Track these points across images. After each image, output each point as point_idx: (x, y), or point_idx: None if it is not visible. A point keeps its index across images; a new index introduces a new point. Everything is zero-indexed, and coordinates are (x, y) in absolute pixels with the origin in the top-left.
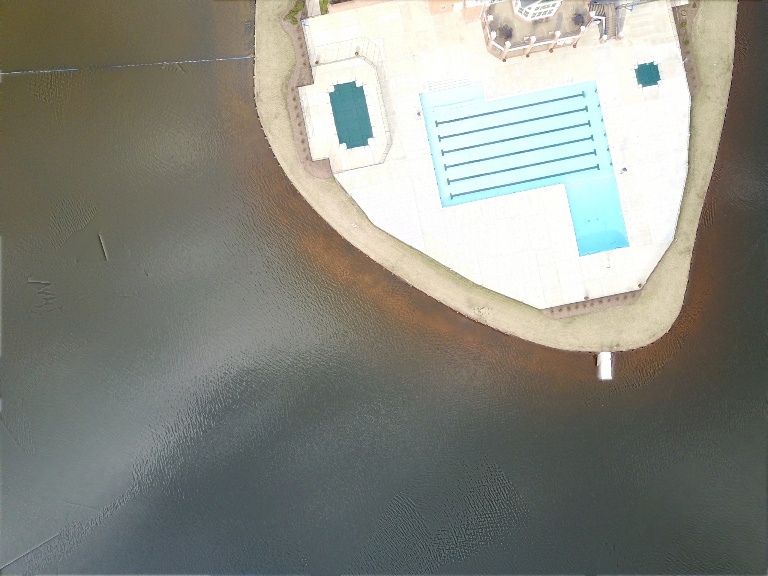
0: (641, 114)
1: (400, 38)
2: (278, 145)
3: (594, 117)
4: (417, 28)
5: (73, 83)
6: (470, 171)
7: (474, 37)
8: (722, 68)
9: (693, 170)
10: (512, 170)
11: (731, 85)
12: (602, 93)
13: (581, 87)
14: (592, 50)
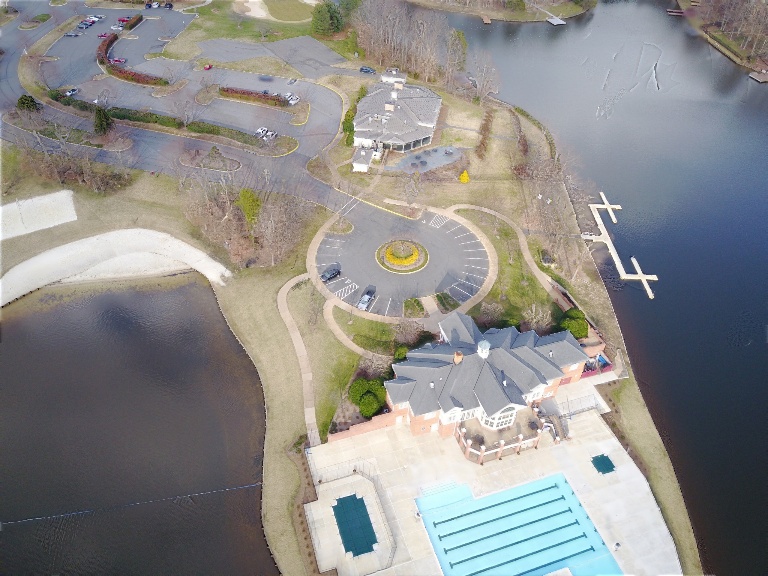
0: (611, 496)
1: (390, 456)
2: (284, 562)
3: (572, 504)
4: (404, 447)
5: (82, 525)
6: (475, 566)
7: (452, 449)
8: (659, 454)
9: (678, 541)
10: (515, 561)
11: (673, 466)
12: (572, 482)
13: (552, 480)
14: (551, 450)
